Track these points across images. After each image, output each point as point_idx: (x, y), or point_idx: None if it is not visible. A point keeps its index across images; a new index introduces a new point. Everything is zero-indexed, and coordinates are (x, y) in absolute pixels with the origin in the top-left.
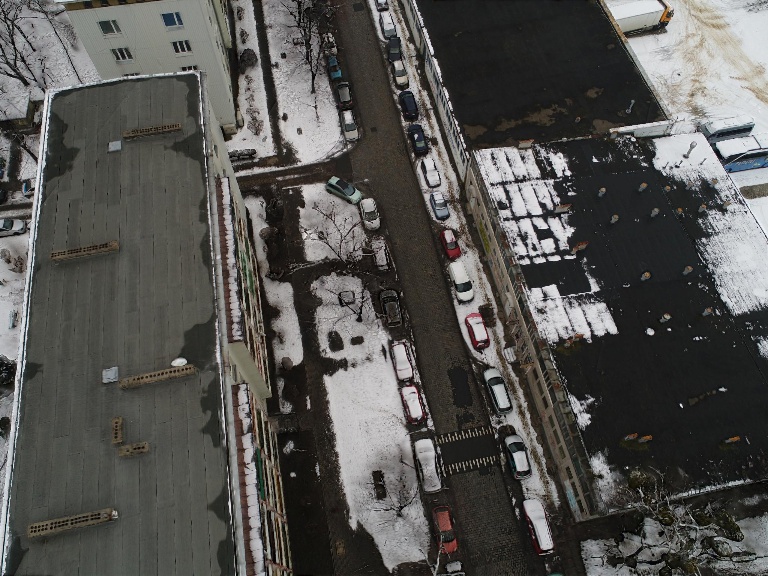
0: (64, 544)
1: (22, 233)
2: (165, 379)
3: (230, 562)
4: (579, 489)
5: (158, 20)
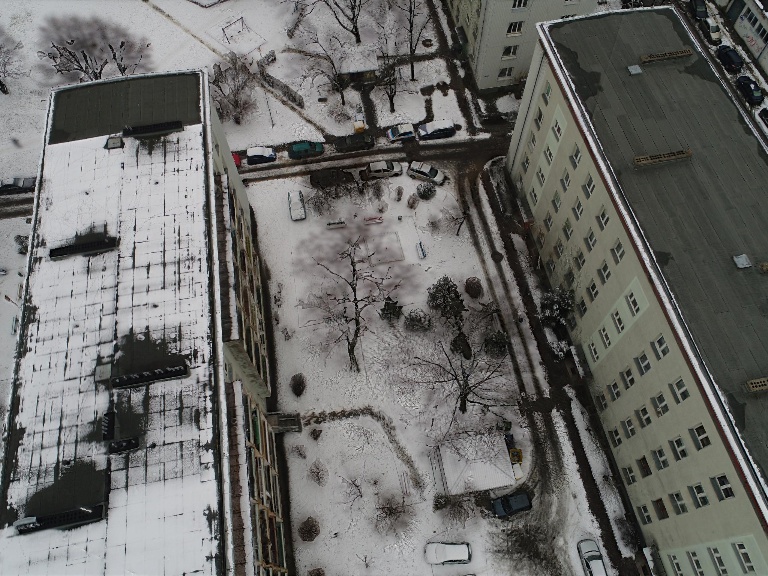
0: None
1: (400, 174)
2: None
3: None
4: None
5: None
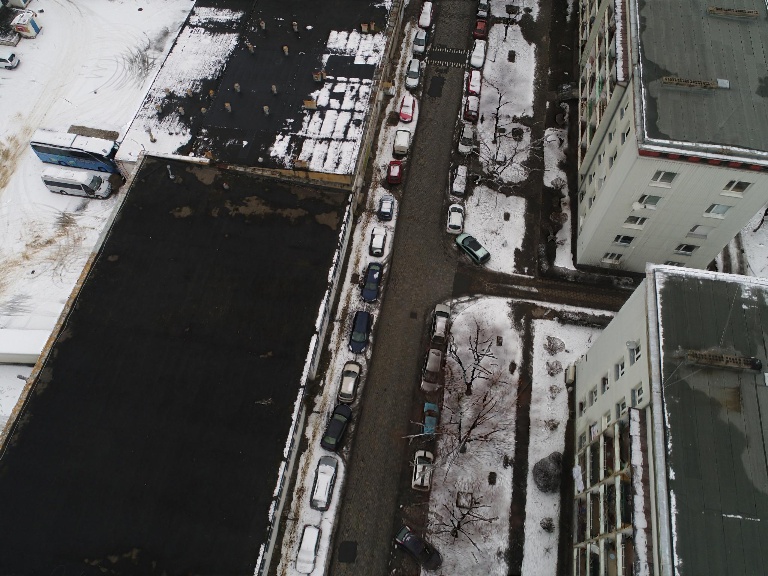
0: None
1: None
2: None
3: None
4: None
5: None
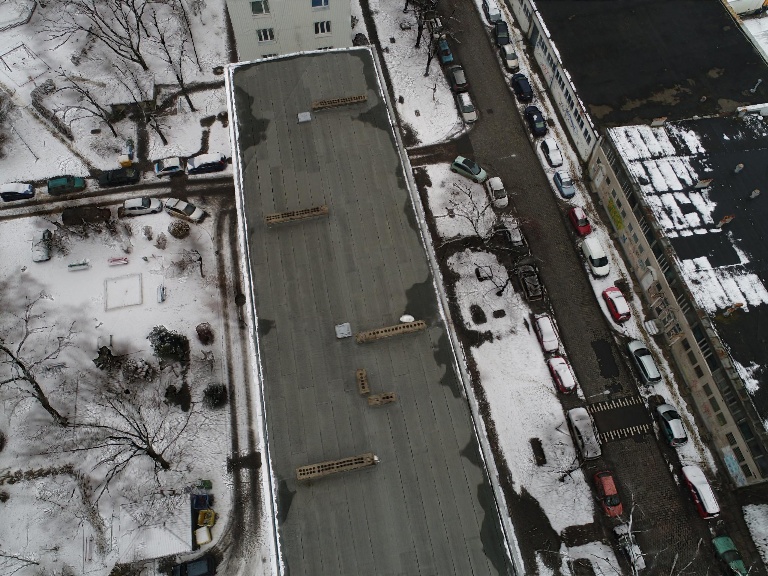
0: (329, 487)
1: (159, 211)
2: (399, 334)
3: (491, 504)
4: (746, 453)
5: (307, 0)
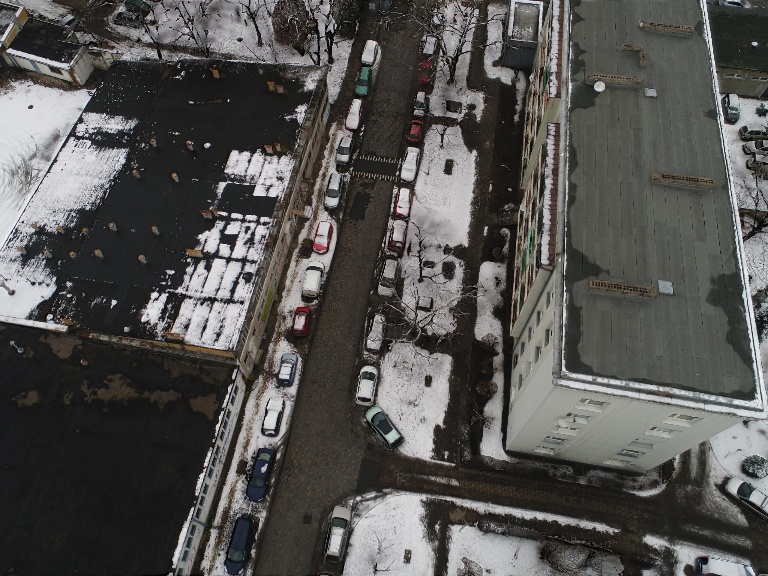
0: None
1: None
2: None
3: None
4: None
5: None
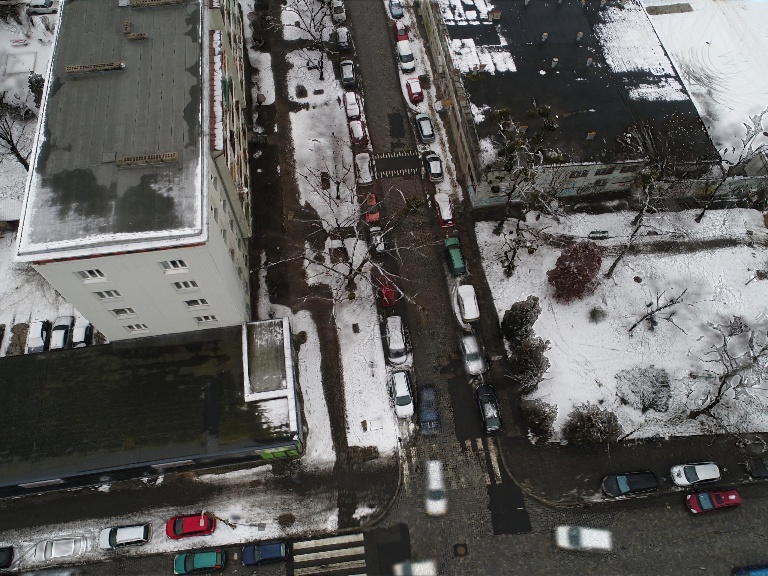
0: (88, 81)
1: None
2: (162, 4)
3: (198, 95)
4: (473, 173)
5: None
